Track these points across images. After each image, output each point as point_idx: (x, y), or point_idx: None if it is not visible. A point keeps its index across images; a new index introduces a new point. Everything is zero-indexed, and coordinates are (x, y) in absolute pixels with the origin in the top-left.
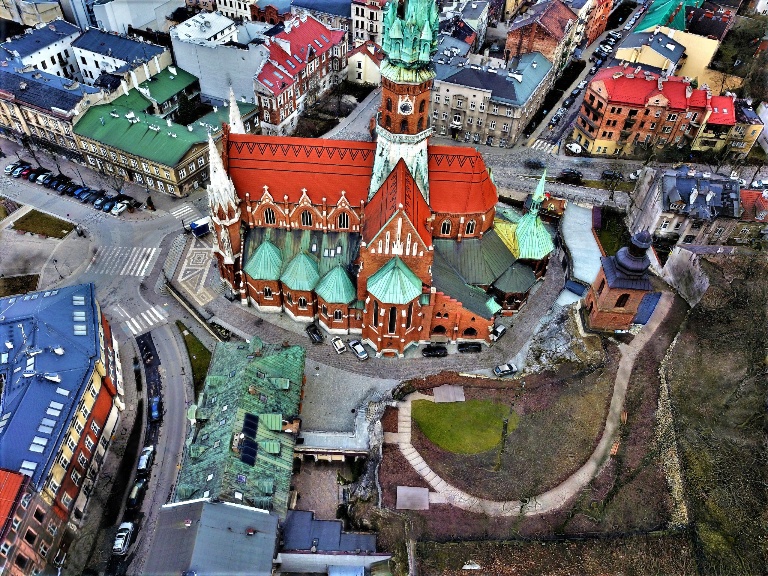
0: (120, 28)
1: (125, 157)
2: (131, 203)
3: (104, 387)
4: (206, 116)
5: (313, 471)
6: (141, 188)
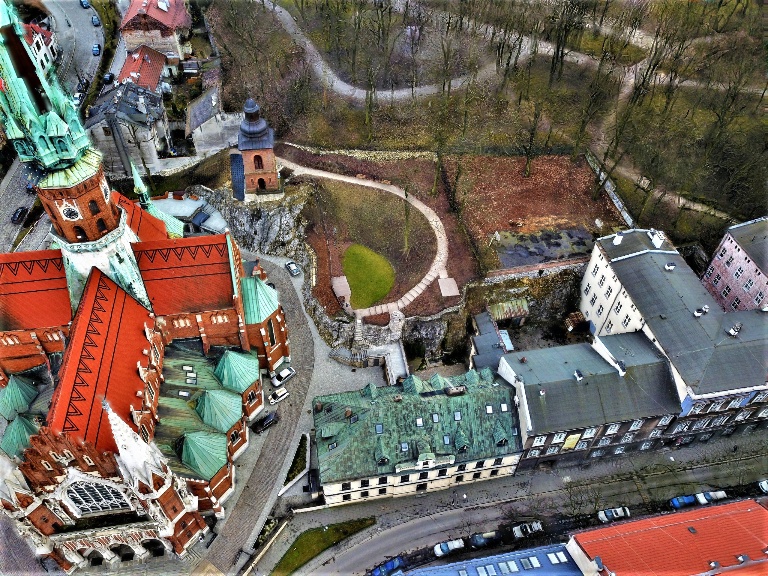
0: None
1: None
2: None
3: None
4: None
5: None
6: None
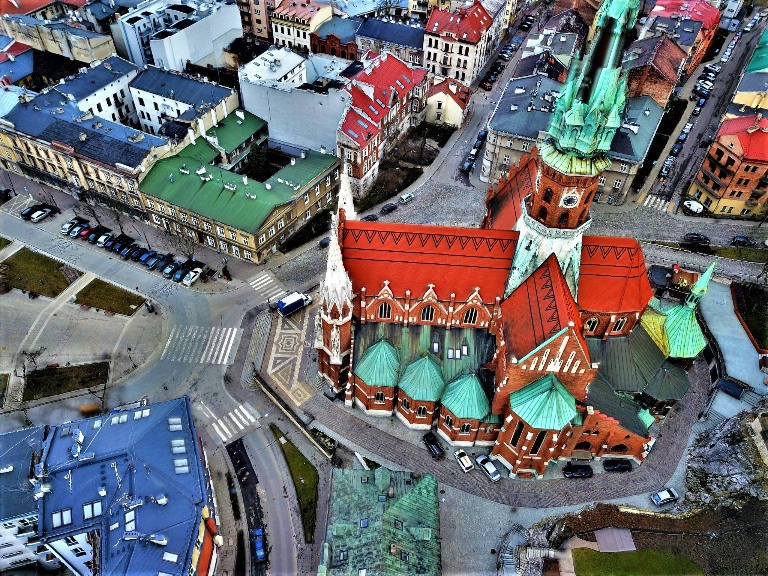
0: (178, 64)
1: (197, 219)
2: (203, 271)
3: (206, 529)
4: (283, 170)
5: None
6: (213, 252)
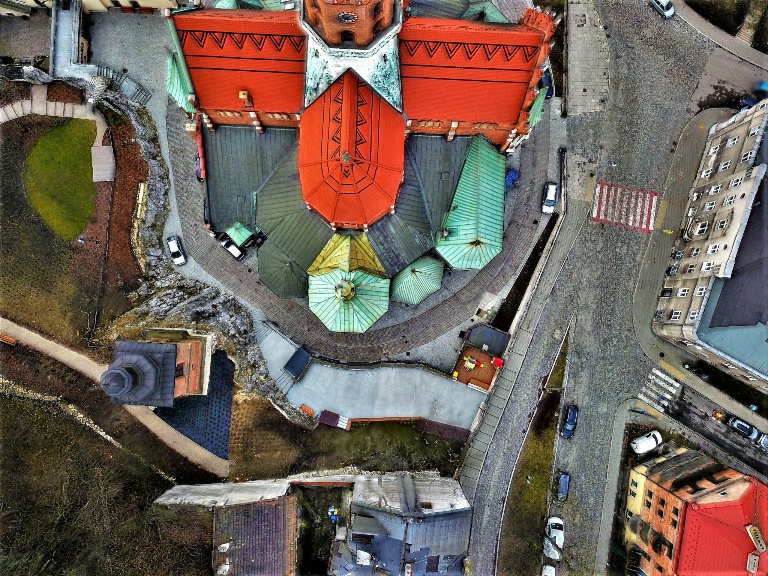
0: None
1: None
2: None
3: None
4: None
5: None
6: None
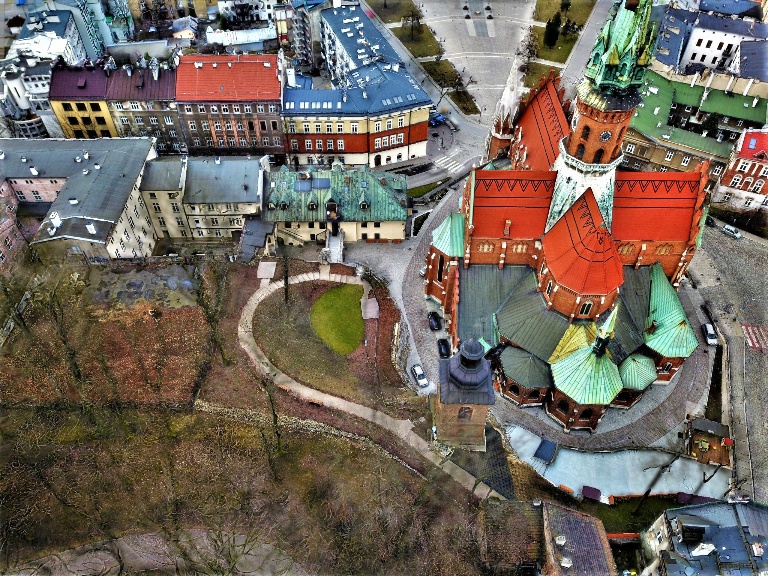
0: None
1: None
2: None
3: (367, 139)
4: (691, 132)
5: (319, 252)
6: None
